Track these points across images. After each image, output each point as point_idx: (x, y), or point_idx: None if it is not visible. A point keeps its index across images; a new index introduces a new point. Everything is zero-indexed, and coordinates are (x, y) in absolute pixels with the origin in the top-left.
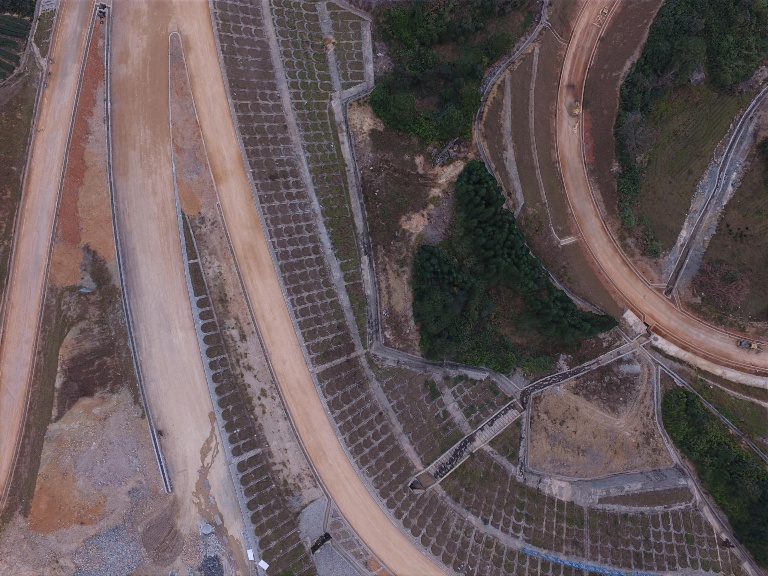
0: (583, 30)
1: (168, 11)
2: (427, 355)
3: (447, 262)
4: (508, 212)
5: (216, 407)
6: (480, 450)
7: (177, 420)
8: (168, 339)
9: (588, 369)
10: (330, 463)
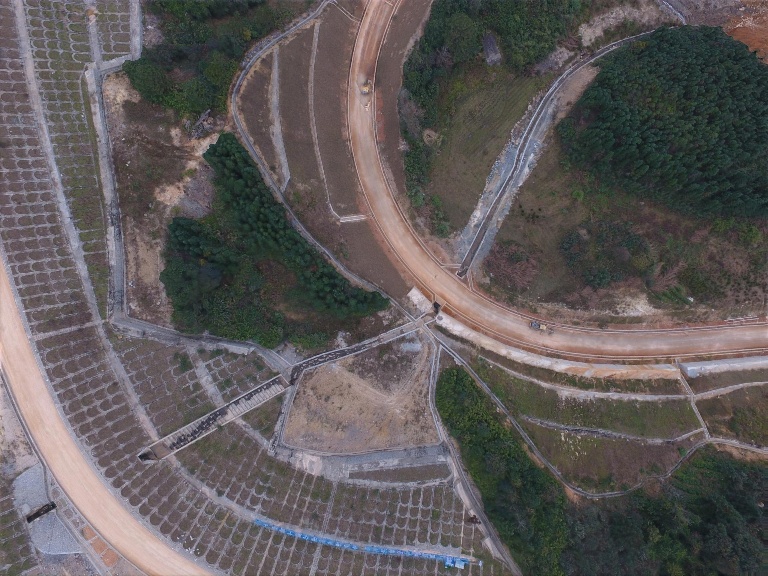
0: (376, 8)
1: None
2: None
3: (208, 235)
4: (258, 185)
5: None
6: (231, 423)
7: None
8: None
9: (368, 347)
10: (47, 431)
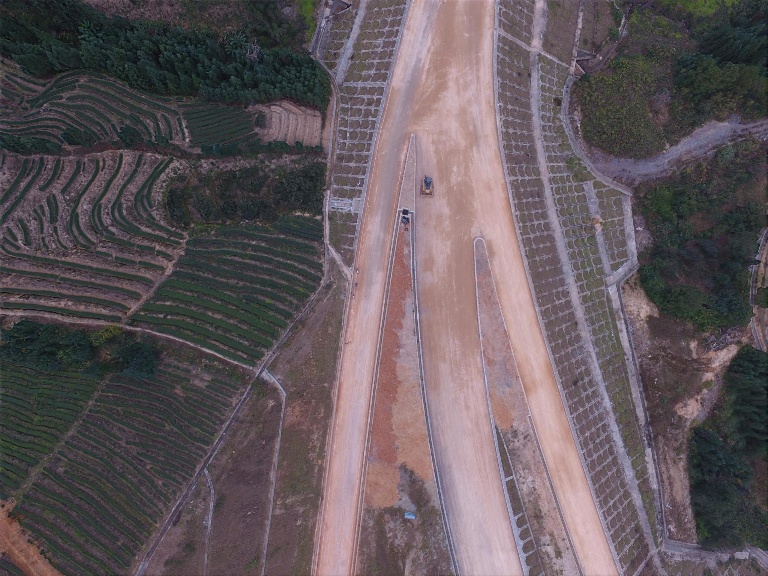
0: None
1: (470, 215)
2: (704, 543)
3: None
4: None
5: None
6: None
7: None
8: (490, 561)
9: None
10: None
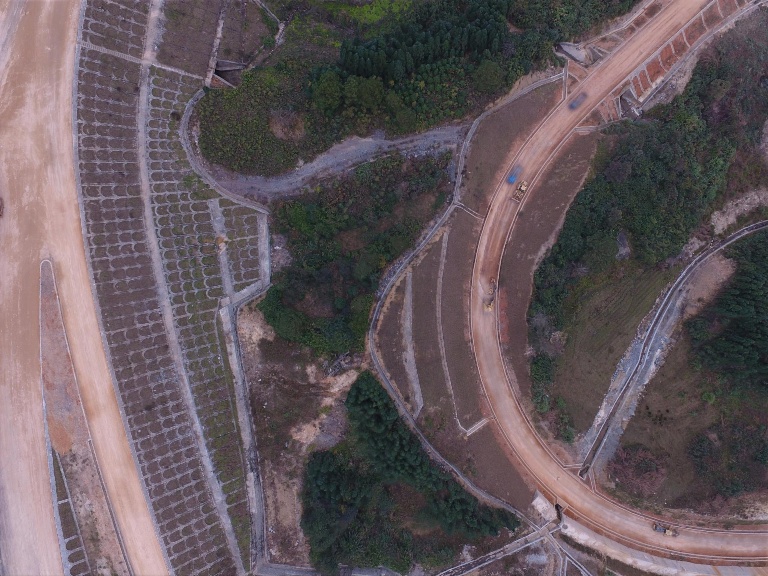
0: (501, 204)
1: (40, 236)
2: (316, 567)
3: (341, 467)
4: (399, 430)
5: None
6: None
7: None
8: None
9: (493, 558)
10: None
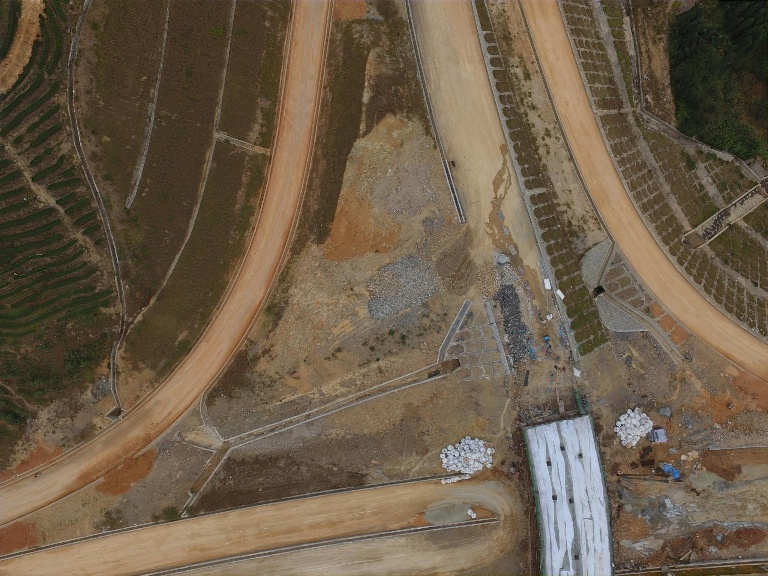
0: None
1: None
2: (683, 126)
3: None
4: None
5: (508, 139)
6: (735, 224)
7: (468, 152)
8: (457, 72)
9: None
10: (613, 207)
